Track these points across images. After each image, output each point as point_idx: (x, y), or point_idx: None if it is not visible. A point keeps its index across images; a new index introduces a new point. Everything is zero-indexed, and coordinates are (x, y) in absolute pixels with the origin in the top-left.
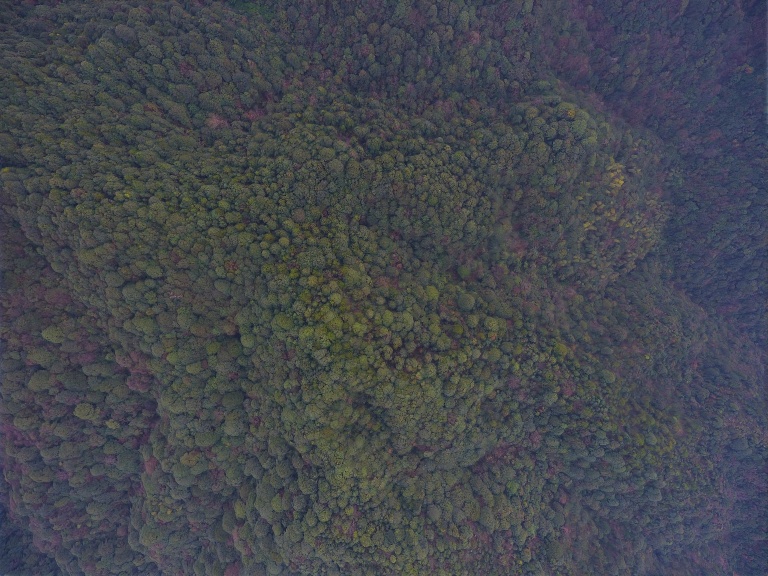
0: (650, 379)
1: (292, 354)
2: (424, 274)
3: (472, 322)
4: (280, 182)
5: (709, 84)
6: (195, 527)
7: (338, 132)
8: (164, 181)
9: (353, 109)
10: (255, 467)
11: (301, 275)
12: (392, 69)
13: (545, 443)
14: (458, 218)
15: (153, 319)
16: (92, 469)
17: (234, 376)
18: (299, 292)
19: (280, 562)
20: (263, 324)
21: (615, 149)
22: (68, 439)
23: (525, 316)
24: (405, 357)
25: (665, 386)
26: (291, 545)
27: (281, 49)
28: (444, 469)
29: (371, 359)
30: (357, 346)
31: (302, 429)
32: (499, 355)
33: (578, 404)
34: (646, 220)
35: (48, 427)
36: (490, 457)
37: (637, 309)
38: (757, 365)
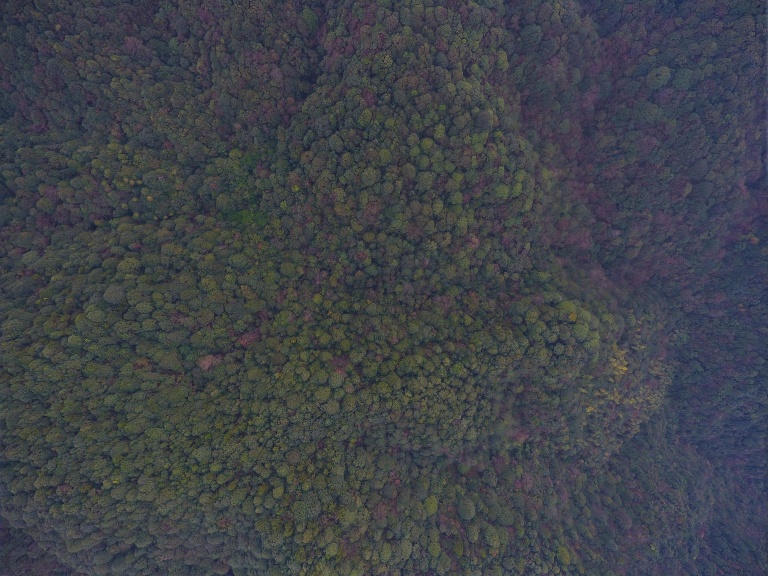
0: (656, 563)
1: None
2: (423, 488)
3: (472, 538)
4: (274, 430)
5: (713, 252)
6: None
7: (334, 356)
8: (154, 455)
9: (349, 320)
10: None
11: (296, 532)
12: (389, 271)
13: None
14: (457, 432)
15: None
16: None
17: None
18: (294, 551)
19: None
20: (257, 570)
21: (618, 335)
22: None
23: (527, 520)
24: None
25: (671, 569)
26: None
27: (275, 260)
28: None
29: None
30: None
31: None
32: (501, 574)
33: None
34: (650, 388)
35: None
36: None
37: (642, 486)
38: (765, 525)
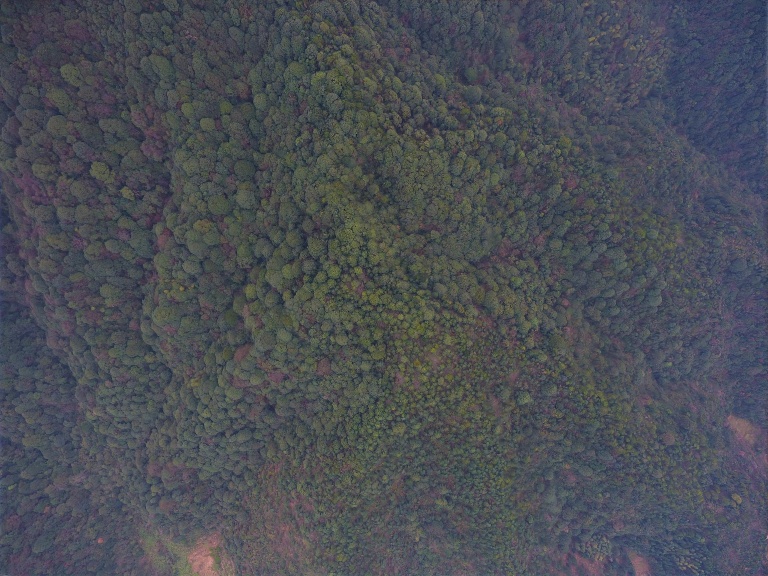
0: (652, 196)
1: (304, 105)
2: (432, 60)
3: (479, 107)
4: None
5: None
6: (206, 314)
7: None
8: None
9: None
10: (266, 245)
11: (314, 20)
12: None
13: (548, 247)
14: (466, 4)
15: (169, 61)
16: (107, 242)
17: (246, 146)
18: (312, 36)
19: (290, 327)
20: (276, 80)
21: None
22: (84, 202)
23: (531, 113)
24: (414, 127)
25: (666, 204)
26: (301, 305)
27: None
28: (450, 257)
29: (381, 117)
30: (367, 99)
31: (313, 183)
32: (505, 138)
33: (582, 198)
34: (650, 50)
35: (65, 181)
36: (495, 256)
37: (640, 132)
38: (757, 205)
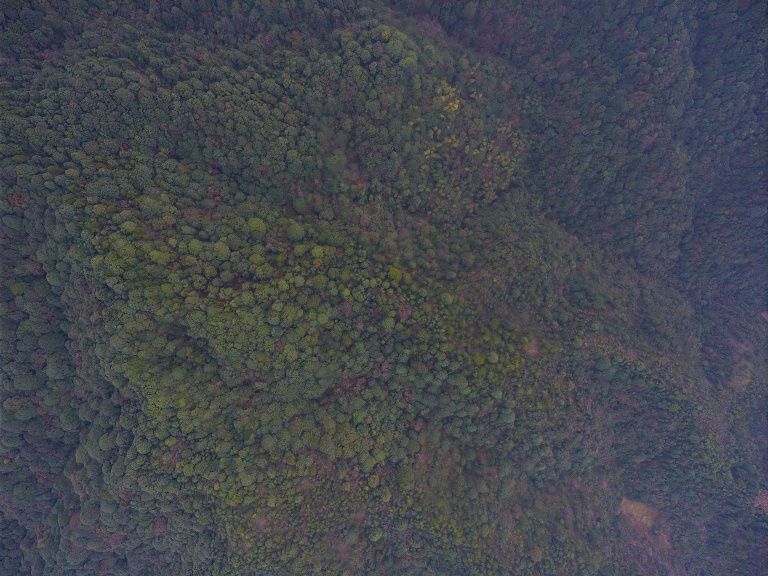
0: (505, 304)
1: (90, 286)
2: (245, 206)
3: (296, 250)
4: (64, 113)
5: (551, 5)
6: (42, 477)
7: (137, 65)
8: None
9: (160, 44)
10: (87, 410)
11: (87, 204)
12: (203, 3)
13: (395, 372)
14: (274, 147)
15: None
16: None
17: (51, 318)
18: (85, 221)
19: (111, 500)
20: None
21: (447, 73)
22: None
23: (358, 244)
24: (220, 286)
25: (522, 310)
26: (115, 480)
27: None
28: (284, 401)
29: (175, 287)
30: (156, 274)
31: (110, 362)
32: (324, 281)
33: (417, 328)
34: (500, 148)
35: None
36: (338, 389)
37: (492, 236)
38: (630, 288)
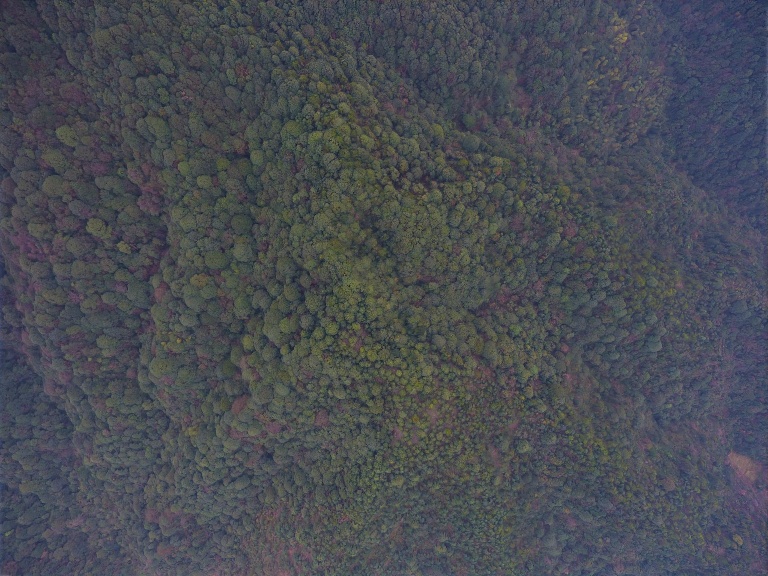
0: (651, 239)
1: (301, 163)
2: (430, 110)
3: (477, 157)
4: None
5: None
6: (203, 364)
7: None
8: None
9: None
10: (263, 297)
11: (310, 80)
12: None
13: (548, 293)
14: (464, 54)
15: (165, 121)
16: (103, 295)
17: (243, 200)
18: (308, 96)
19: (288, 382)
20: (272, 137)
21: (619, 5)
22: (80, 258)
23: (529, 160)
24: (411, 181)
25: (666, 247)
26: (299, 361)
27: None
28: (448, 306)
29: (378, 173)
30: (365, 157)
31: (310, 241)
32: (503, 189)
33: (581, 246)
34: (649, 90)
35: (61, 239)
36: (493, 303)
37: (639, 174)
38: (757, 242)
